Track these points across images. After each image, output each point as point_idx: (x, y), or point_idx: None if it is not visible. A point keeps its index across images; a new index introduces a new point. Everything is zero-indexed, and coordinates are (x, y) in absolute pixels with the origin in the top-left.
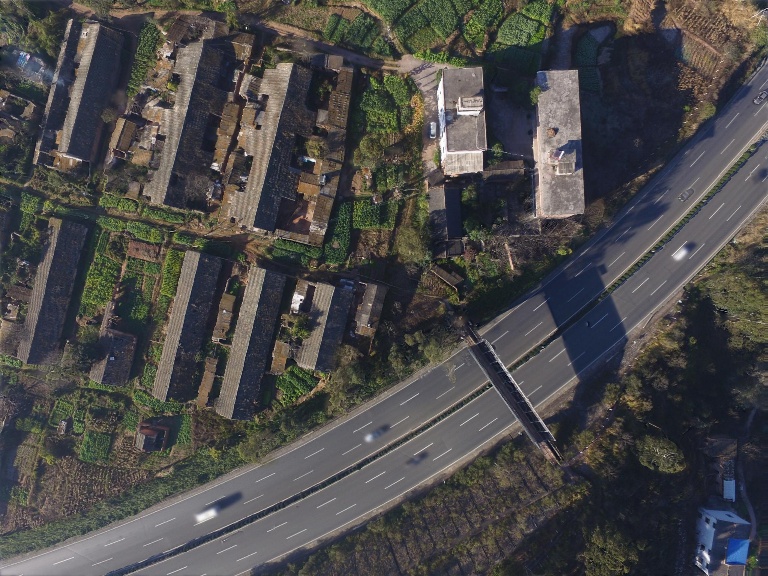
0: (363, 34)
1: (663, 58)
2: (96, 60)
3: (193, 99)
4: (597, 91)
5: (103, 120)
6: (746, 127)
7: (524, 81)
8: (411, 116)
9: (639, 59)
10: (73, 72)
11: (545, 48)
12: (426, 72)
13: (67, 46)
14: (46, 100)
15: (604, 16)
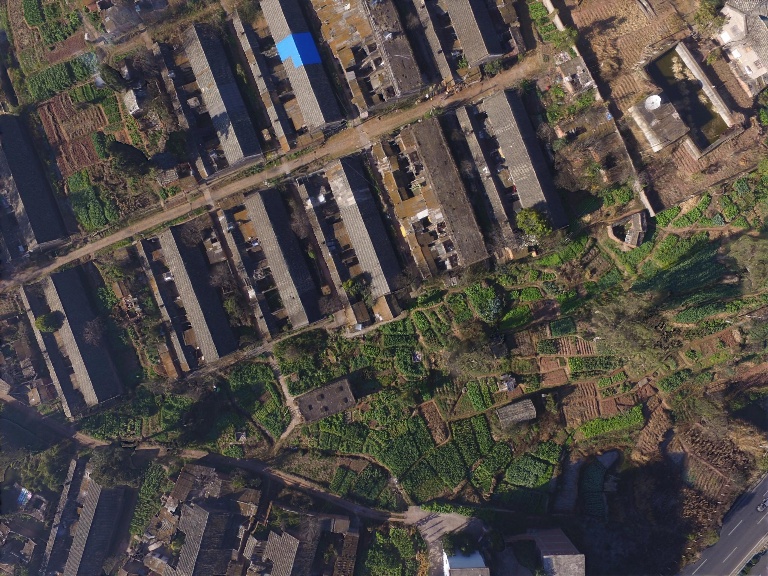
0: (370, 487)
1: (669, 483)
2: (99, 512)
3: (197, 568)
4: (602, 516)
5: (105, 570)
6: (749, 535)
7: (530, 561)
8: (416, 569)
9: (645, 486)
10: (75, 511)
11: (552, 487)
12: (432, 522)
13: (70, 489)
14: (47, 532)
15: (612, 445)
